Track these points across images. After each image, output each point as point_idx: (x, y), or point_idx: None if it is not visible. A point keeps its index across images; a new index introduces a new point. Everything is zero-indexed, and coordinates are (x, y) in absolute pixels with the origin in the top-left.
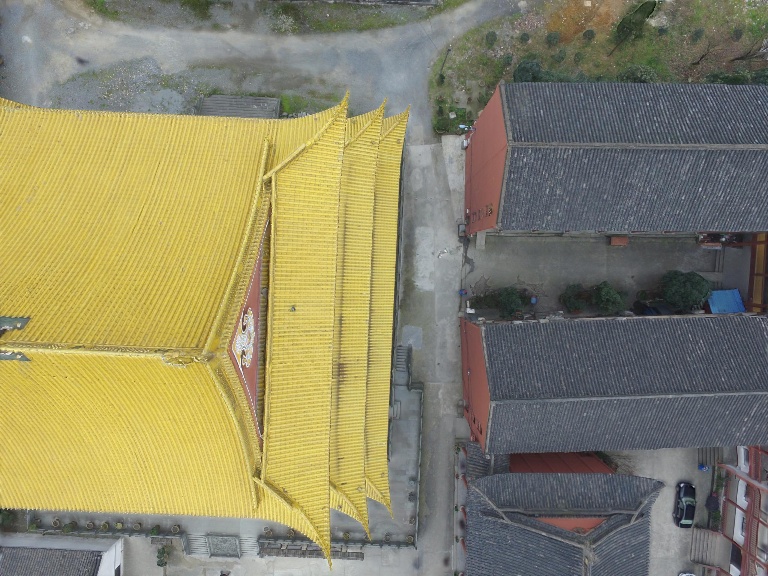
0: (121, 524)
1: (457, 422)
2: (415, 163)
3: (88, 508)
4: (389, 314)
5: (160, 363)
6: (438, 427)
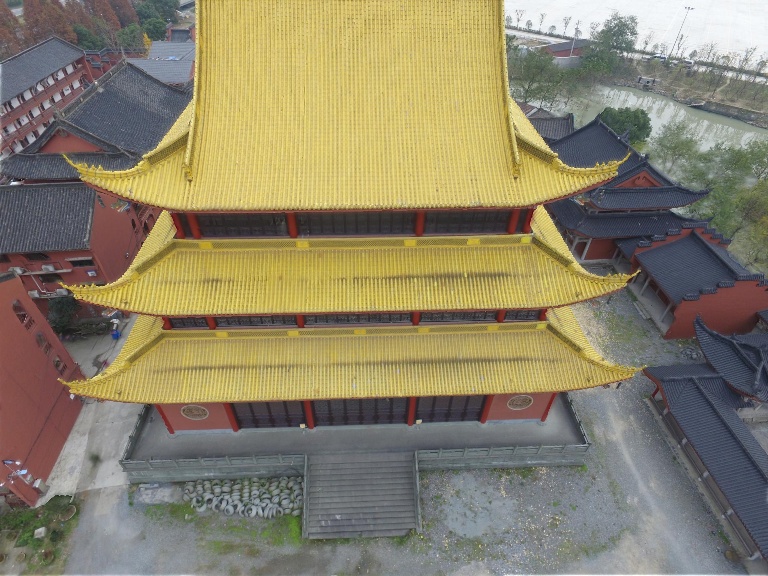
0: None
1: None
2: None
3: None
4: None
5: None
6: None
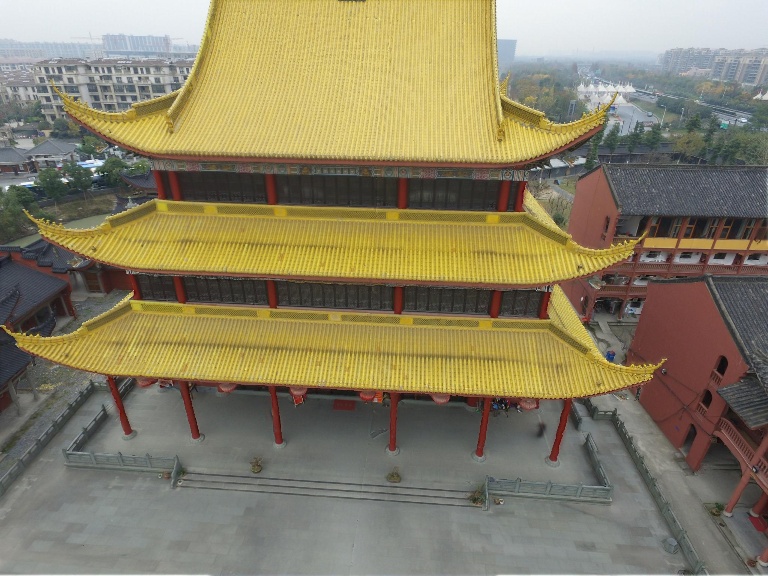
0: None
1: (690, 481)
2: None
3: (299, 155)
4: None
5: (450, 0)
6: (664, 487)
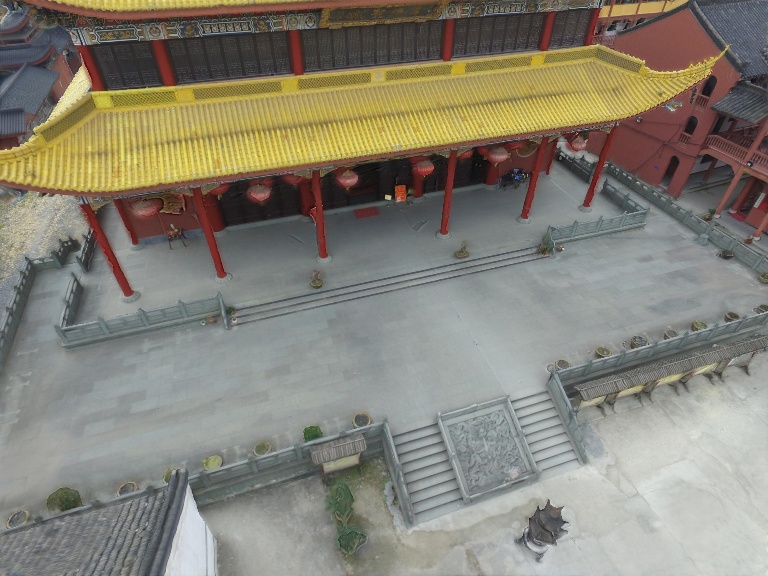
0: (219, 457)
1: None
2: None
3: None
4: None
5: None
6: None
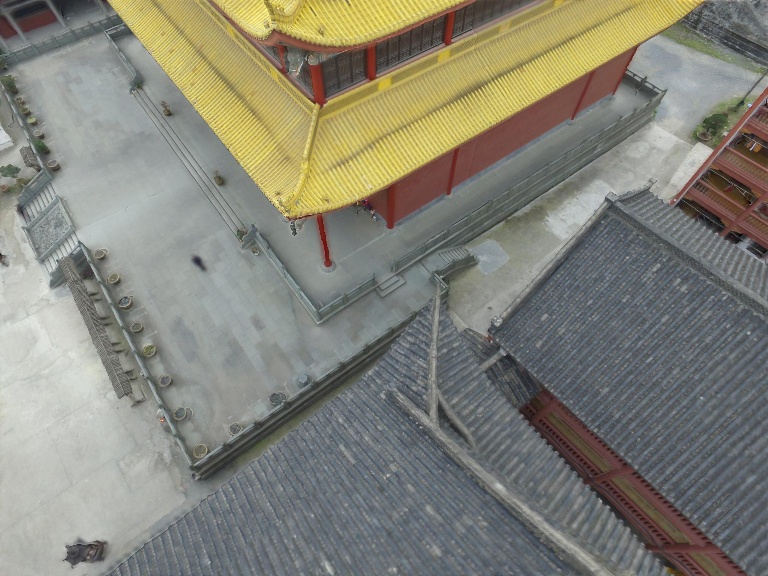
0: (35, 120)
1: None
2: (649, 139)
3: None
4: (534, 94)
5: None
6: None
